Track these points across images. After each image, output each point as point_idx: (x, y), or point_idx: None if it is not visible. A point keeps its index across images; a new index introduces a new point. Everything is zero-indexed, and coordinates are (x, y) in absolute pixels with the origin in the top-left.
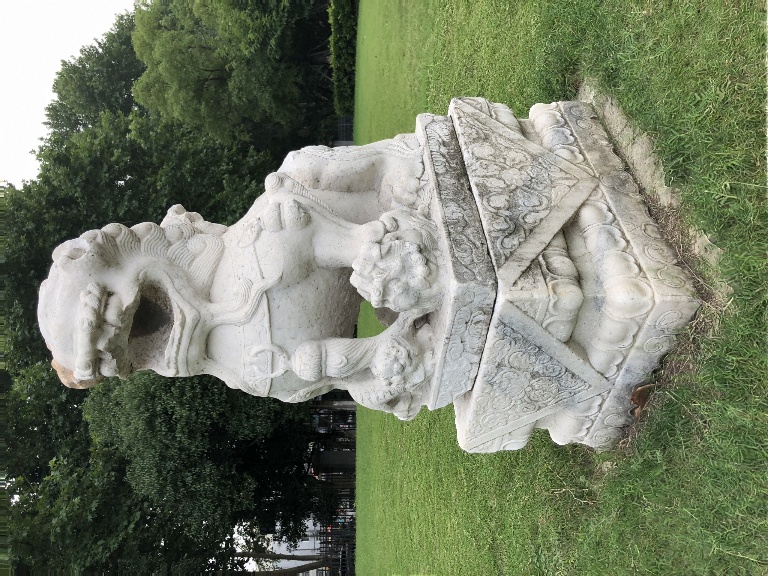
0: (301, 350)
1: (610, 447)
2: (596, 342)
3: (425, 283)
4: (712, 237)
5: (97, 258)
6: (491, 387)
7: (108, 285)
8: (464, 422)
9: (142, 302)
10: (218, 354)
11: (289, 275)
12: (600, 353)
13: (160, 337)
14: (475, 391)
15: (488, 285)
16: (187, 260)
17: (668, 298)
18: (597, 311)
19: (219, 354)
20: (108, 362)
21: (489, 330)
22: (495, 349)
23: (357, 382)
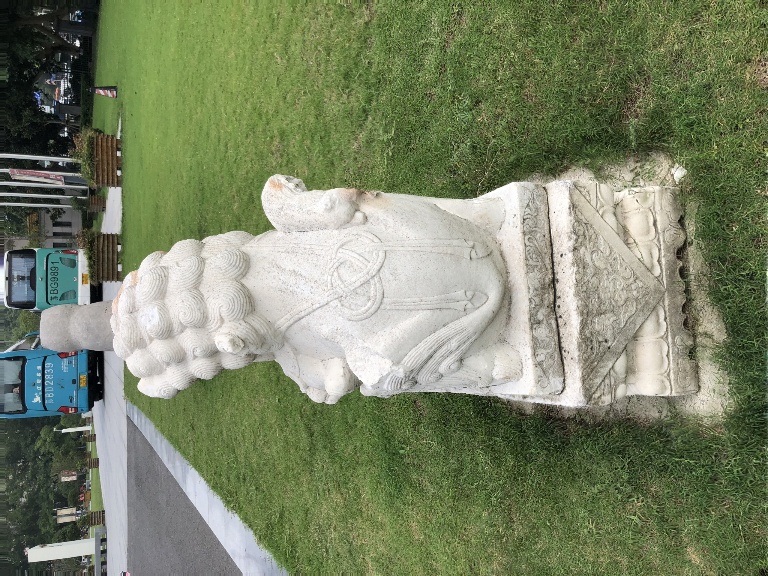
0: None
1: None
2: None
3: None
4: None
5: None
6: None
7: None
8: None
9: None
10: None
11: None
12: None
13: None
14: None
15: None
16: None
17: None
18: None
19: None
20: None
21: None
22: None
23: None
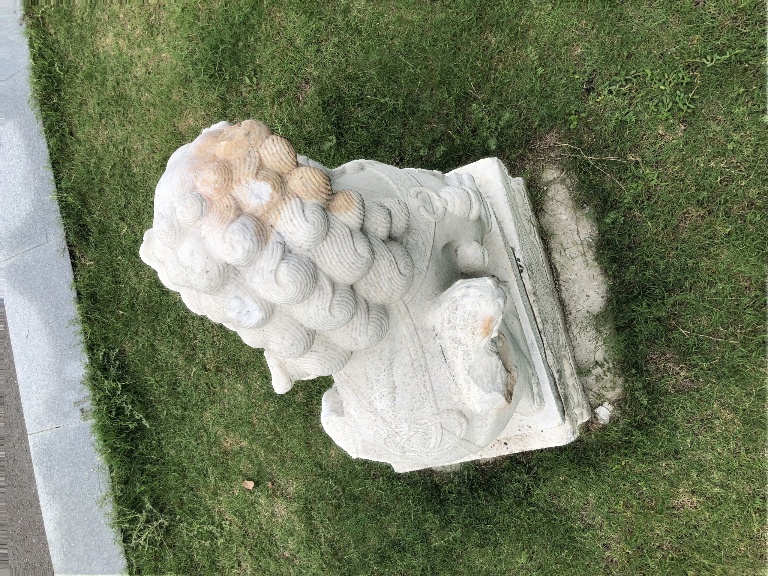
0: None
1: None
2: None
3: None
4: None
5: None
6: None
7: None
8: None
9: None
10: None
11: None
12: None
13: None
14: None
15: None
16: None
17: None
18: None
19: None
20: None
21: None
22: None
23: None
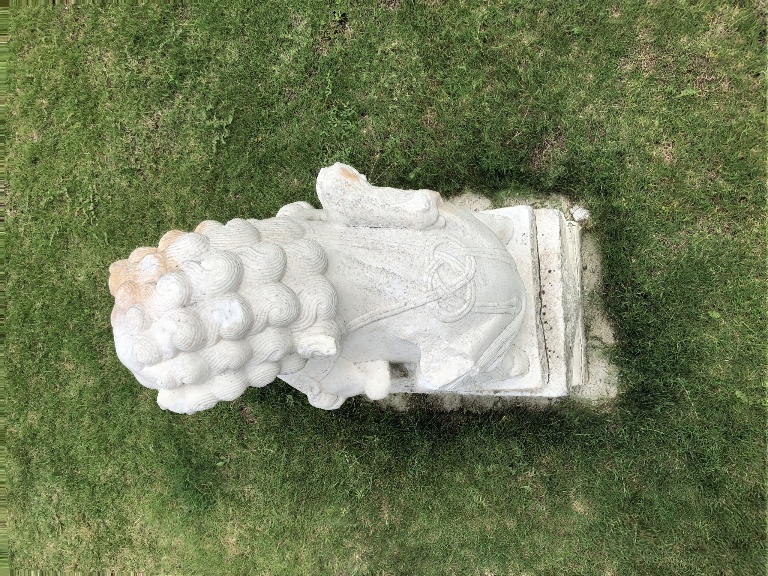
0: None
1: None
2: None
3: None
4: None
5: None
6: None
7: None
8: None
9: None
10: None
11: None
12: None
13: None
14: None
15: None
16: None
17: None
18: None
19: None
20: None
21: None
22: None
23: None
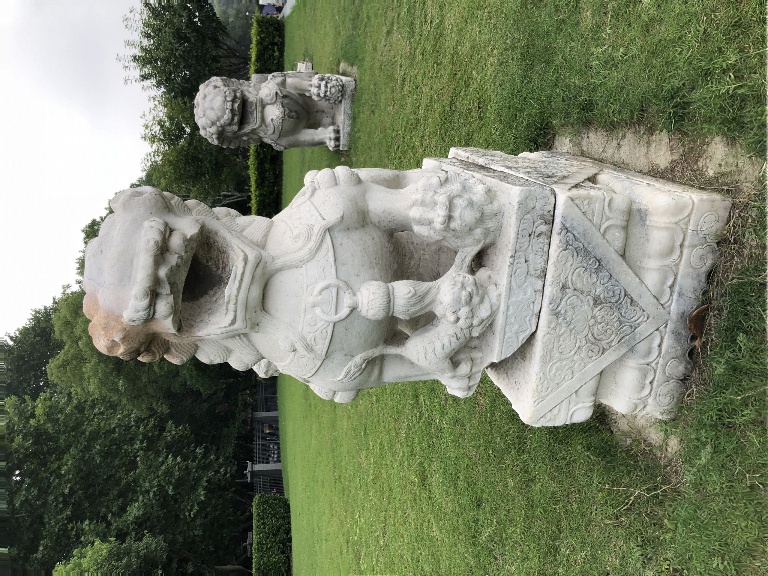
0: (367, 285)
1: (675, 411)
2: (647, 262)
3: (487, 197)
4: (729, 129)
5: (160, 197)
6: (556, 320)
7: (169, 223)
8: (528, 384)
9: (193, 262)
10: (275, 307)
11: (349, 217)
12: (653, 273)
13: (209, 300)
14: (540, 329)
15: (547, 189)
16: (237, 230)
17: (704, 197)
18: (642, 227)
19: (276, 307)
20: (165, 297)
21: (551, 243)
22: (559, 264)
23: (418, 336)
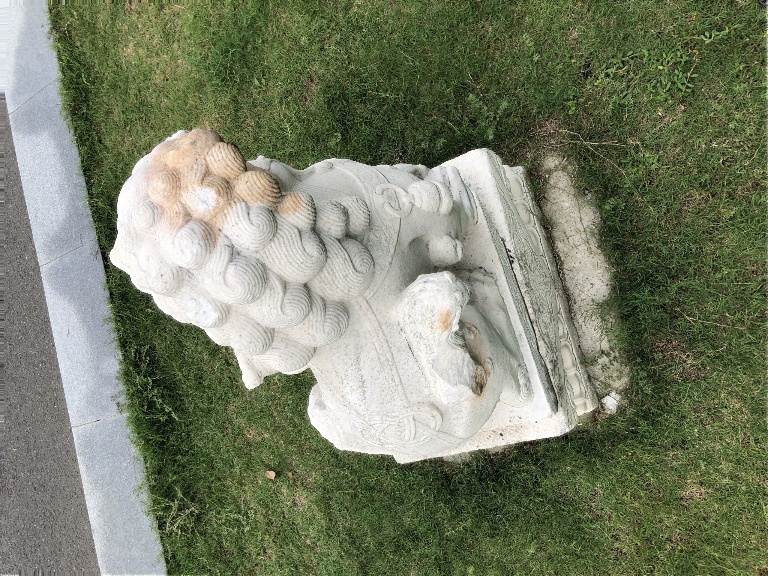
0: None
1: None
2: None
3: None
4: None
5: None
6: None
7: None
8: None
9: None
10: None
11: None
12: None
13: None
14: None
15: None
16: None
17: None
18: None
19: None
20: None
21: None
22: None
23: None
